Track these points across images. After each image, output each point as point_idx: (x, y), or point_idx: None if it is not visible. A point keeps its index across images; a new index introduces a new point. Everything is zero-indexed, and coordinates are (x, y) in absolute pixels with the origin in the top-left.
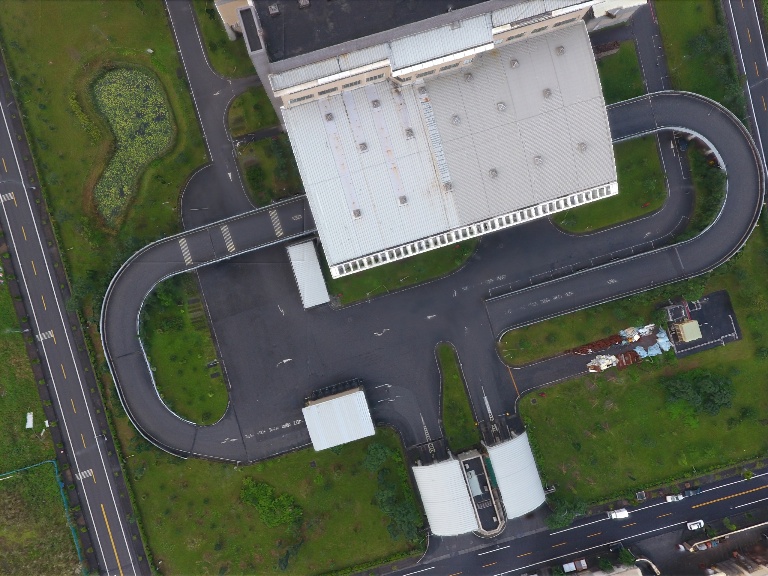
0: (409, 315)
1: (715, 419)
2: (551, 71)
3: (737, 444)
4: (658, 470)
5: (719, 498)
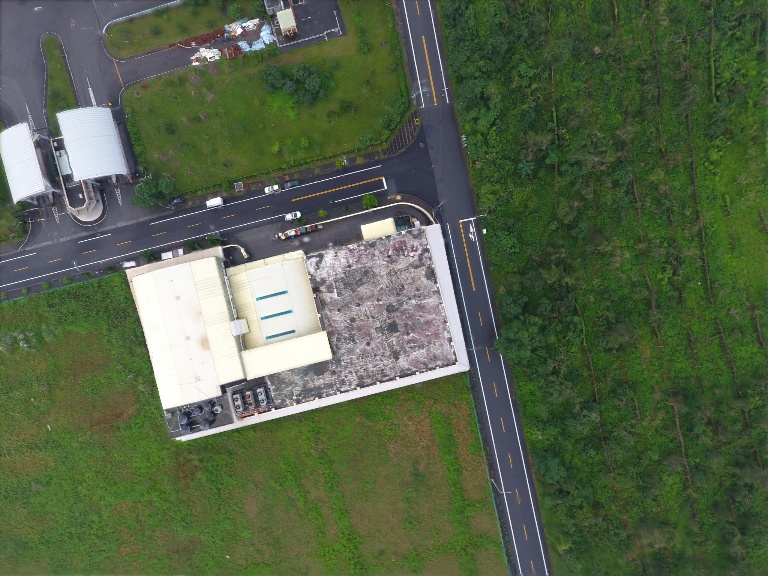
0: (16, 6)
1: (315, 112)
2: None
3: (337, 138)
4: (258, 162)
5: (319, 192)
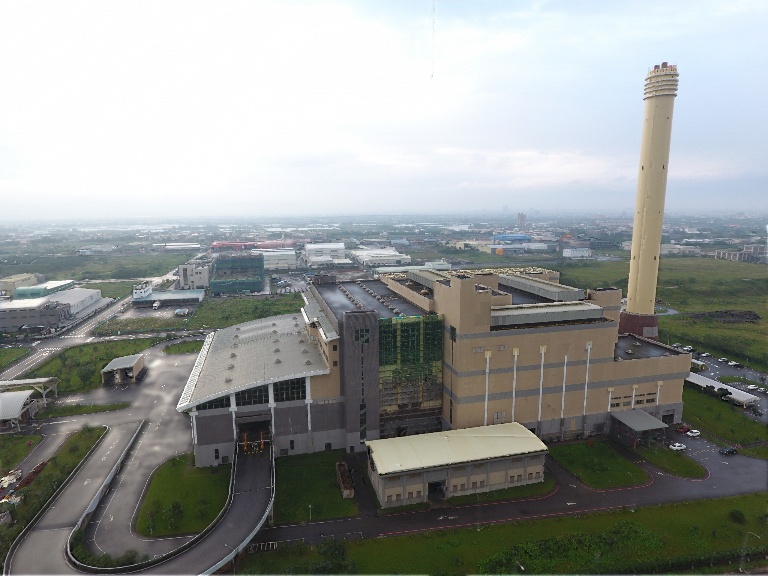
0: (165, 395)
1: None
2: (294, 362)
3: None
4: None
5: None
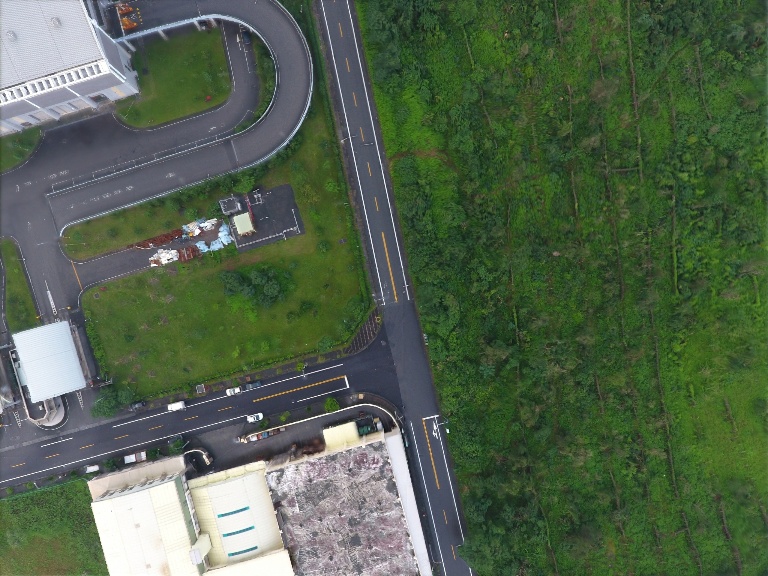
0: None
1: (275, 313)
2: None
3: (298, 338)
4: (219, 364)
5: (281, 392)
